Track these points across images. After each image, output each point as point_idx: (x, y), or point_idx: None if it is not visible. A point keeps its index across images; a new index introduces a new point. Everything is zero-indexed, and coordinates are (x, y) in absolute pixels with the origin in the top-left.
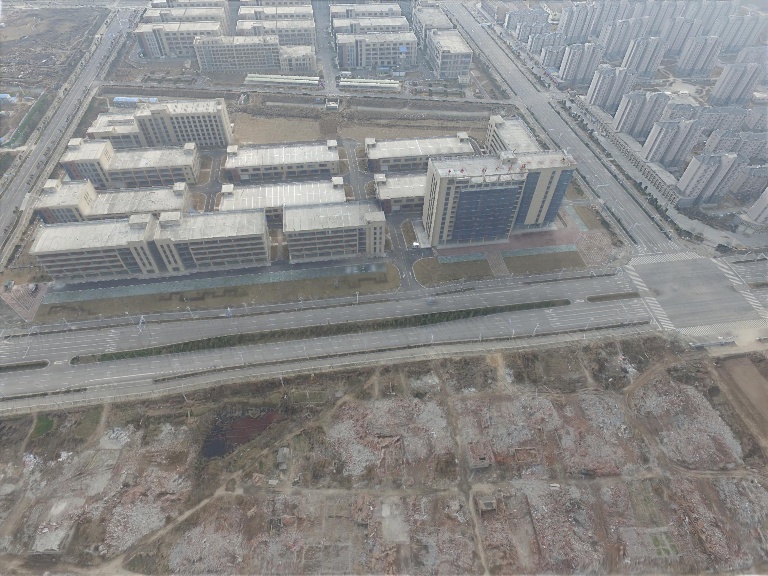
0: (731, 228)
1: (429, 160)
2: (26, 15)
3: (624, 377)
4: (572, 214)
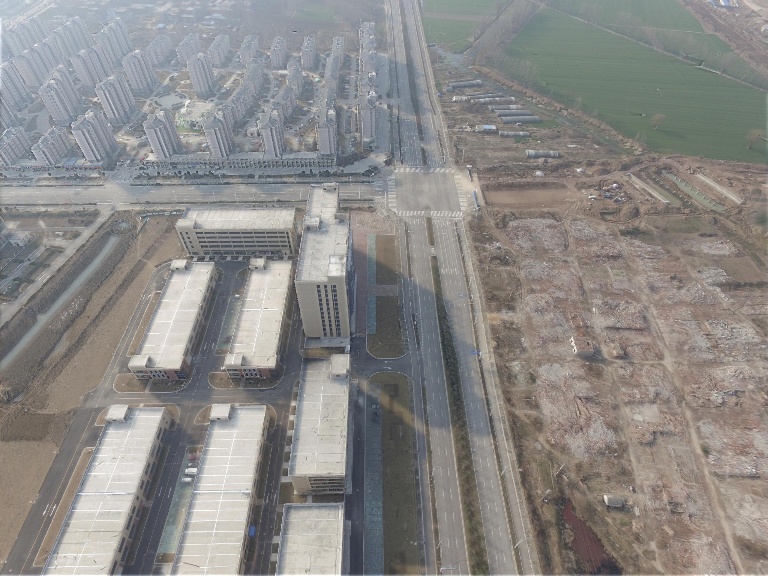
0: (368, 151)
1: (298, 282)
2: None
3: (505, 250)
4: None
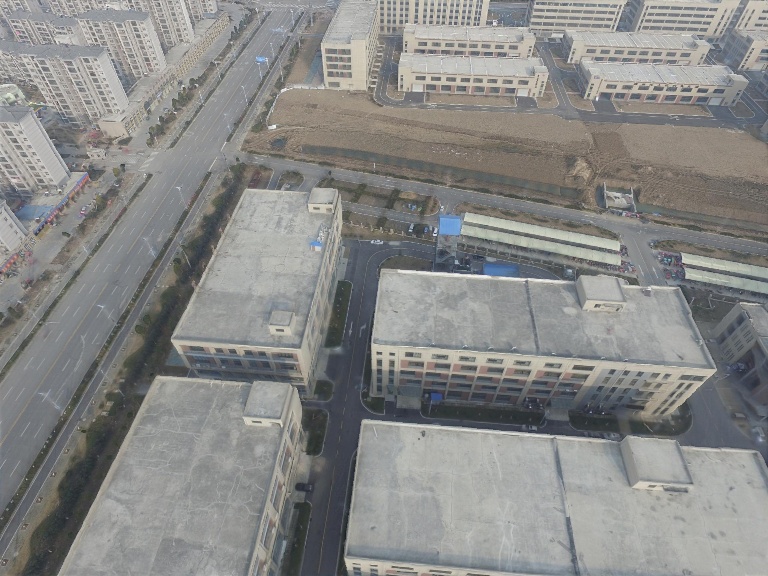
0: None
1: None
2: None
3: None
4: None
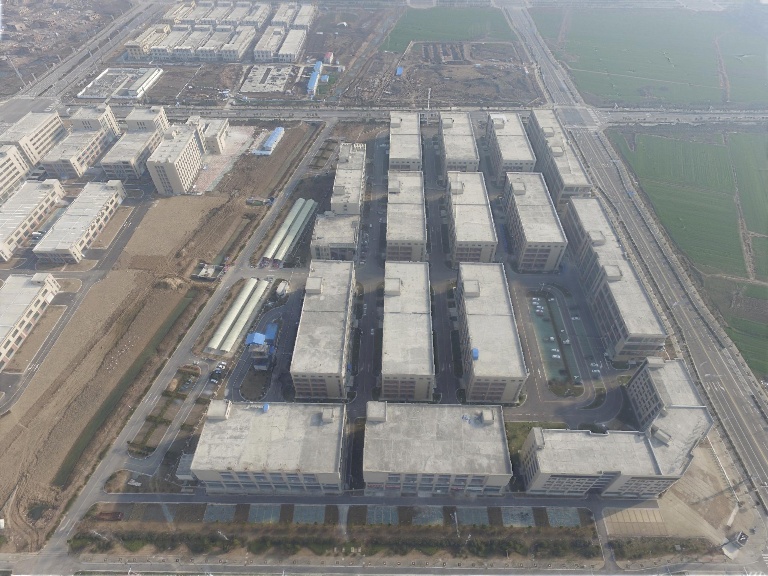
0: None
1: None
2: (508, 71)
3: None
4: None
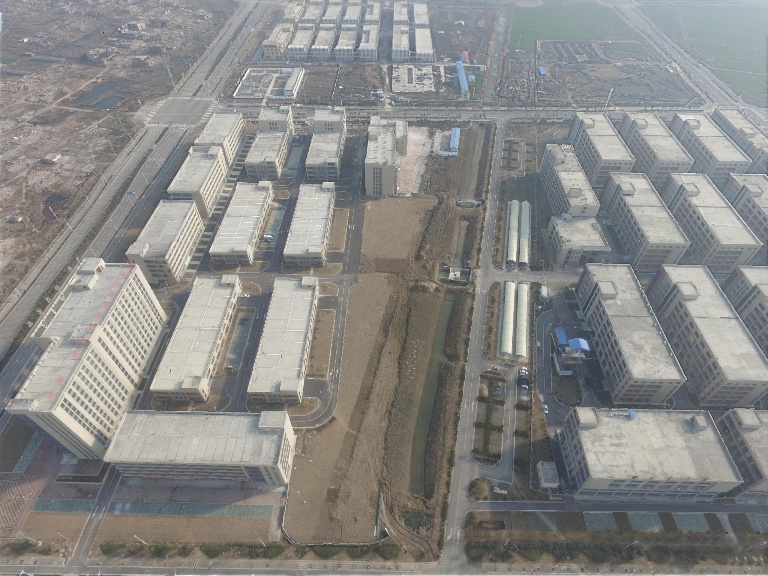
0: None
1: None
2: (652, 70)
3: None
4: (74, 503)
